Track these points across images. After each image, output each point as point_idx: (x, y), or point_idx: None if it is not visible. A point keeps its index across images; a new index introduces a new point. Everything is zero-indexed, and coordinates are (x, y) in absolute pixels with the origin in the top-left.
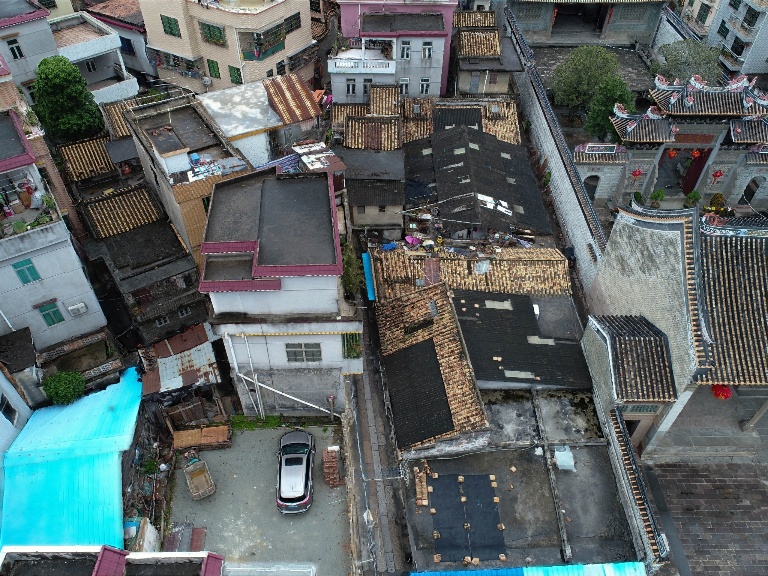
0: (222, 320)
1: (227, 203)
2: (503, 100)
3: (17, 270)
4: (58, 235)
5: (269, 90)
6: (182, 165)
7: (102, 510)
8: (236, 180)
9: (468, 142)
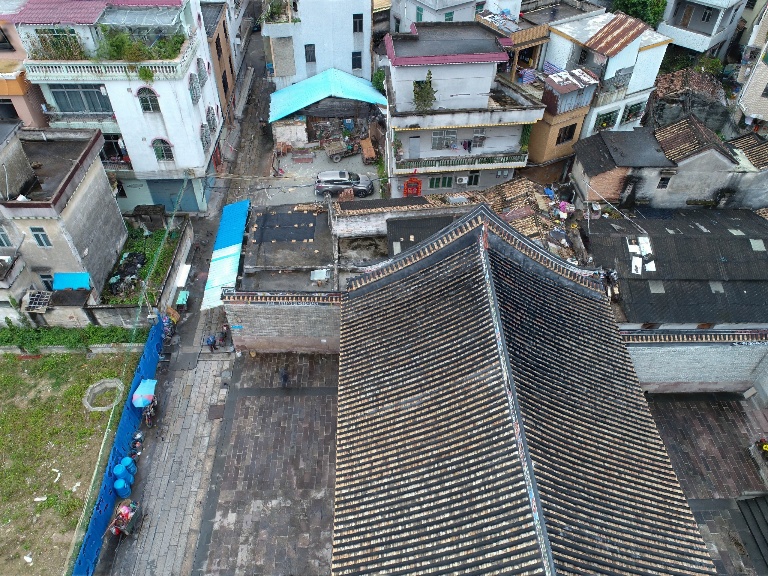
0: (387, 70)
1: (464, 30)
2: None
3: (418, 11)
4: (433, 3)
5: (613, 21)
6: (494, 8)
7: (304, 102)
8: (488, 29)
9: (761, 238)
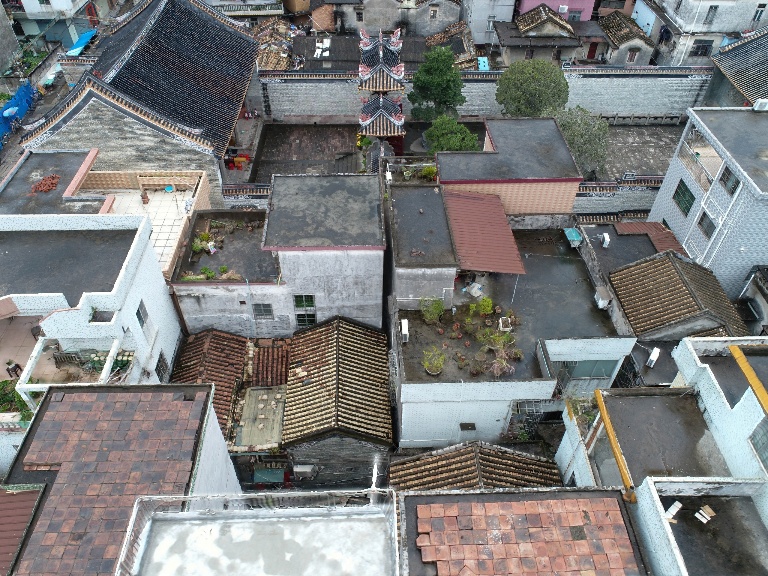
0: None
1: None
2: (472, 55)
3: None
4: None
5: None
6: None
7: None
8: None
9: None
